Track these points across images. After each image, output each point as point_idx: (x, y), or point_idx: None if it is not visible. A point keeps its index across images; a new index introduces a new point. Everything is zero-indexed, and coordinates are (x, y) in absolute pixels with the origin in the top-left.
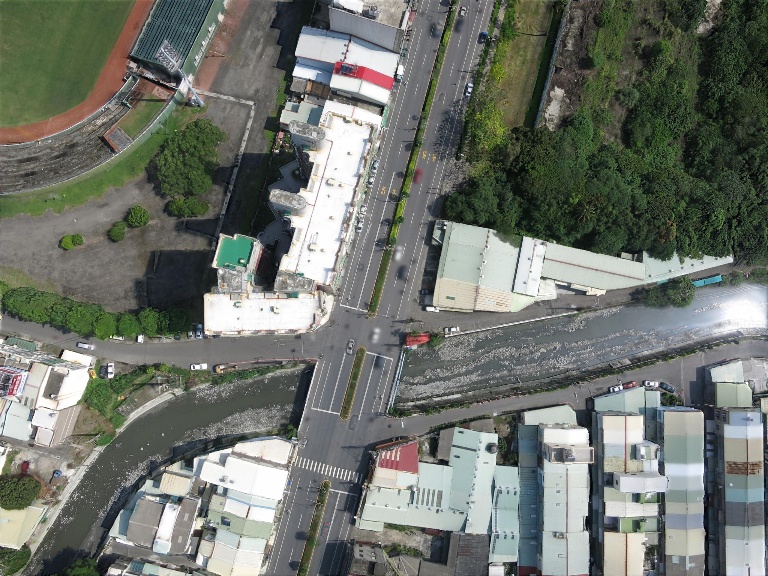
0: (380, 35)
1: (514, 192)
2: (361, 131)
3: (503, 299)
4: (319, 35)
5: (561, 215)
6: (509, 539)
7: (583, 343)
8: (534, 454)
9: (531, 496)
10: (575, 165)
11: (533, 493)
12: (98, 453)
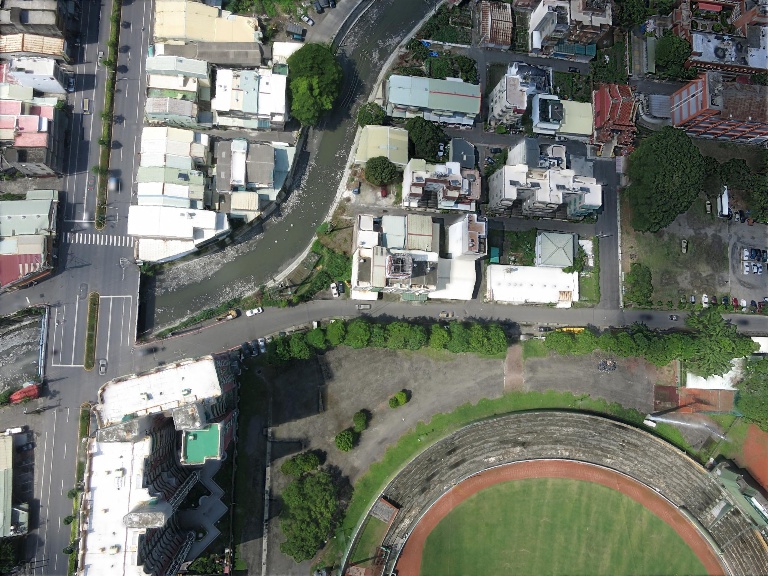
0: None
1: None
2: None
3: None
4: None
5: None
6: None
7: None
8: None
9: None
10: None
11: None
12: (329, 215)
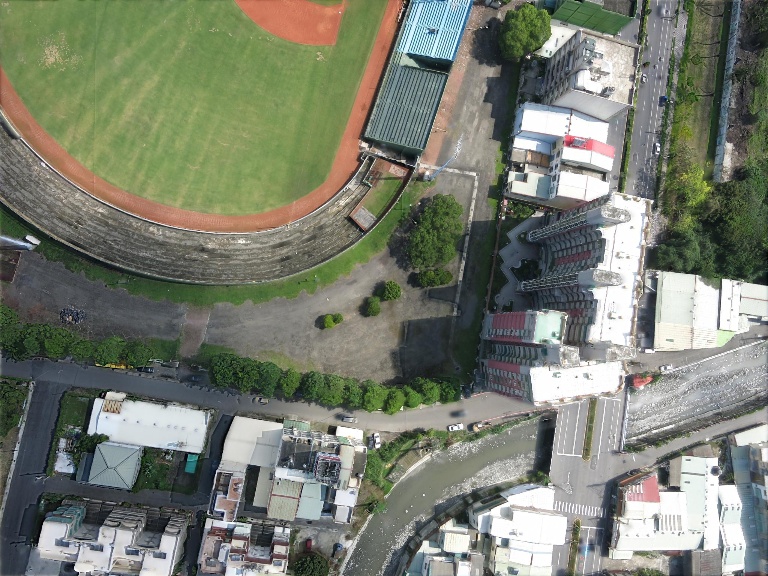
0: (603, 109)
1: (710, 240)
2: (638, 206)
3: (711, 336)
4: (542, 110)
5: (752, 257)
6: (738, 550)
7: (766, 367)
8: (747, 471)
9: (748, 509)
10: (759, 212)
11: (750, 506)
12: (368, 521)
